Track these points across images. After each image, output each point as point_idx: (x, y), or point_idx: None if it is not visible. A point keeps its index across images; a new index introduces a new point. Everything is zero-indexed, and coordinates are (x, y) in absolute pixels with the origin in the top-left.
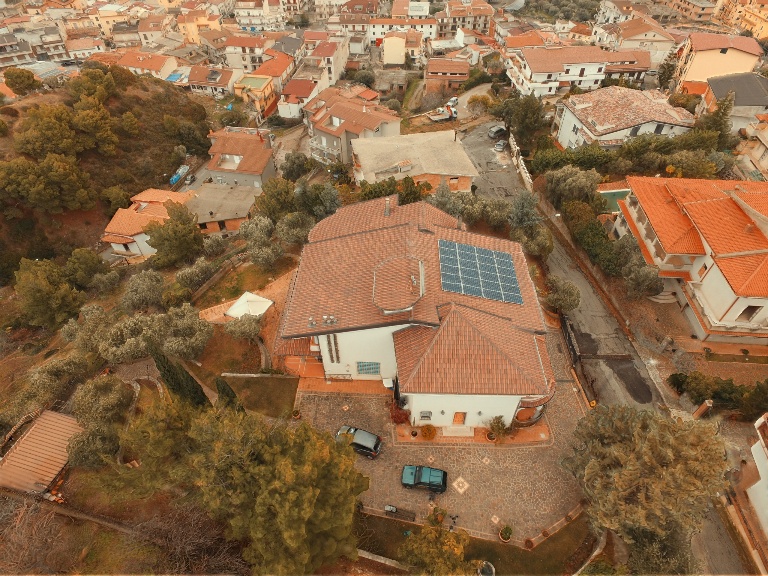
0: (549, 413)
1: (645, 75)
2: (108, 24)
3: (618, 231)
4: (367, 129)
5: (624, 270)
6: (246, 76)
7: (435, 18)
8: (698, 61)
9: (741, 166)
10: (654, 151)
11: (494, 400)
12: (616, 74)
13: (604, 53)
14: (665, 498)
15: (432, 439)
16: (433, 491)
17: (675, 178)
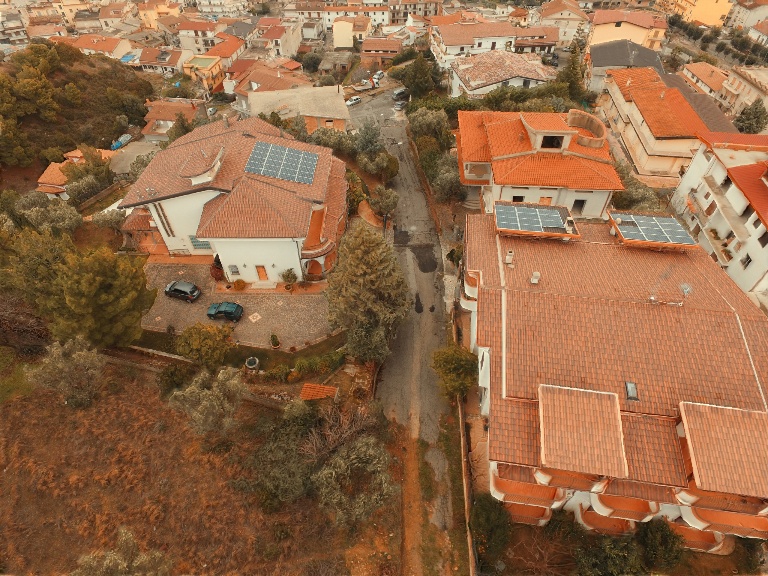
0: None
1: (563, 52)
2: (72, 12)
3: None
4: None
5: None
6: (196, 57)
7: (387, 5)
8: (597, 34)
9: (597, 116)
10: (510, 100)
11: (279, 252)
12: (527, 48)
13: (517, 29)
14: (352, 285)
15: (242, 290)
16: (230, 320)
17: None
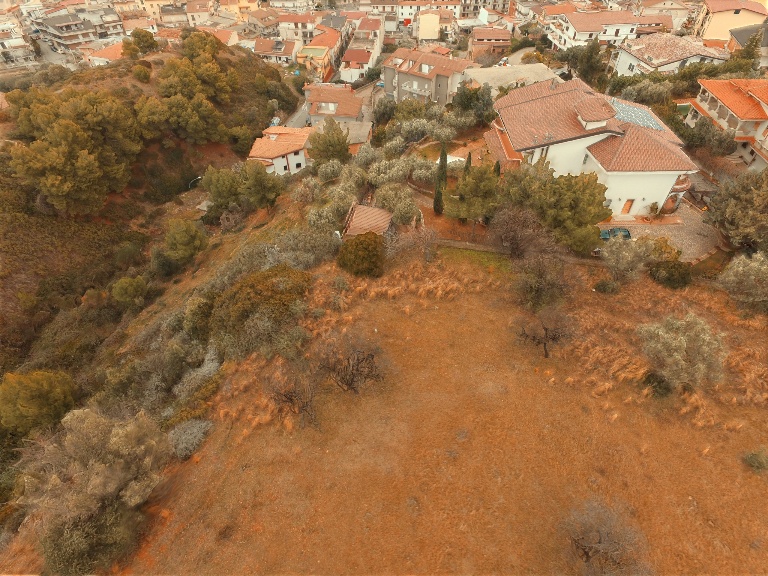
0: (676, 215)
1: None
2: (152, 7)
3: (689, 124)
4: (456, 72)
5: (708, 136)
6: (305, 47)
7: None
8: (715, 21)
9: None
10: (704, 74)
11: (656, 186)
12: None
13: None
14: None
15: (609, 222)
16: None
17: None
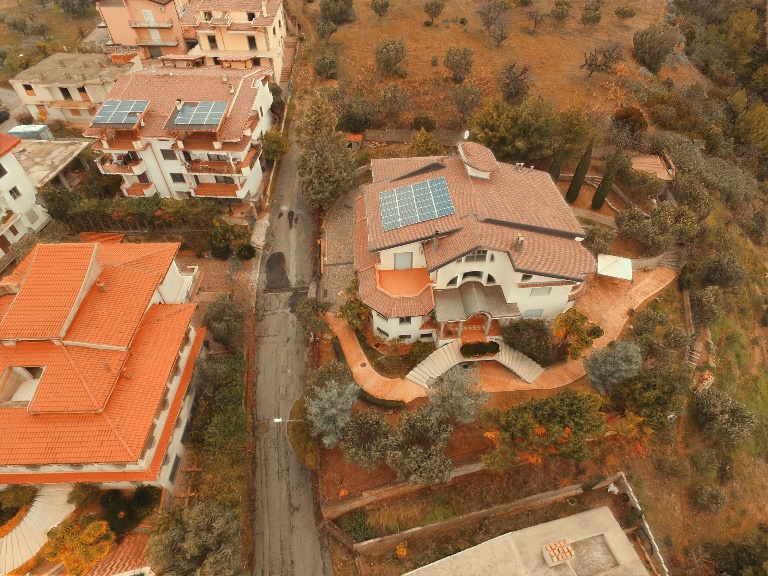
0: None
1: None
2: None
3: None
4: None
5: None
6: None
7: None
8: None
9: None
10: None
11: None
12: None
13: None
14: None
15: None
16: None
17: (49, 462)
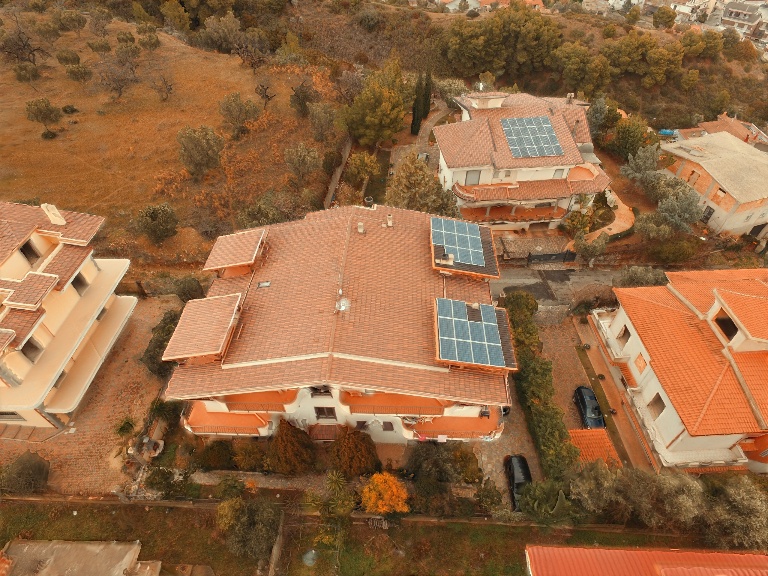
0: None
1: None
2: None
3: None
4: None
5: None
6: None
7: None
8: None
9: None
10: None
11: None
12: None
13: None
14: None
15: None
16: None
17: None
